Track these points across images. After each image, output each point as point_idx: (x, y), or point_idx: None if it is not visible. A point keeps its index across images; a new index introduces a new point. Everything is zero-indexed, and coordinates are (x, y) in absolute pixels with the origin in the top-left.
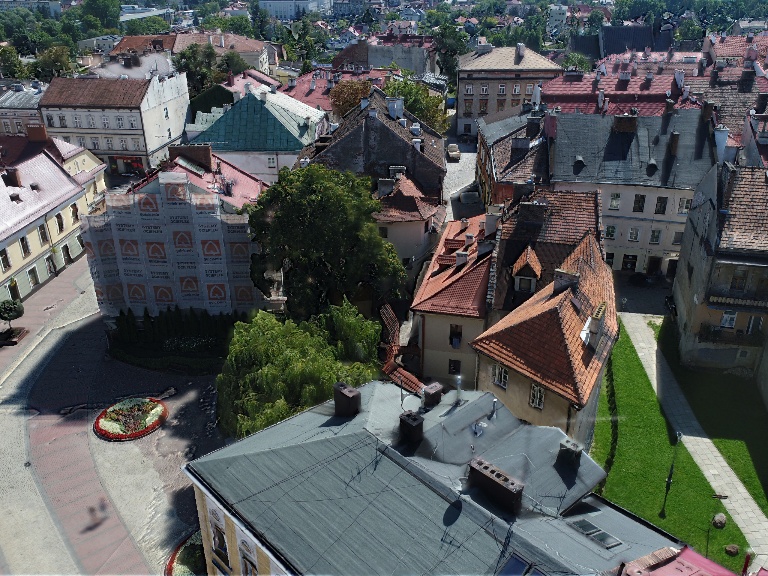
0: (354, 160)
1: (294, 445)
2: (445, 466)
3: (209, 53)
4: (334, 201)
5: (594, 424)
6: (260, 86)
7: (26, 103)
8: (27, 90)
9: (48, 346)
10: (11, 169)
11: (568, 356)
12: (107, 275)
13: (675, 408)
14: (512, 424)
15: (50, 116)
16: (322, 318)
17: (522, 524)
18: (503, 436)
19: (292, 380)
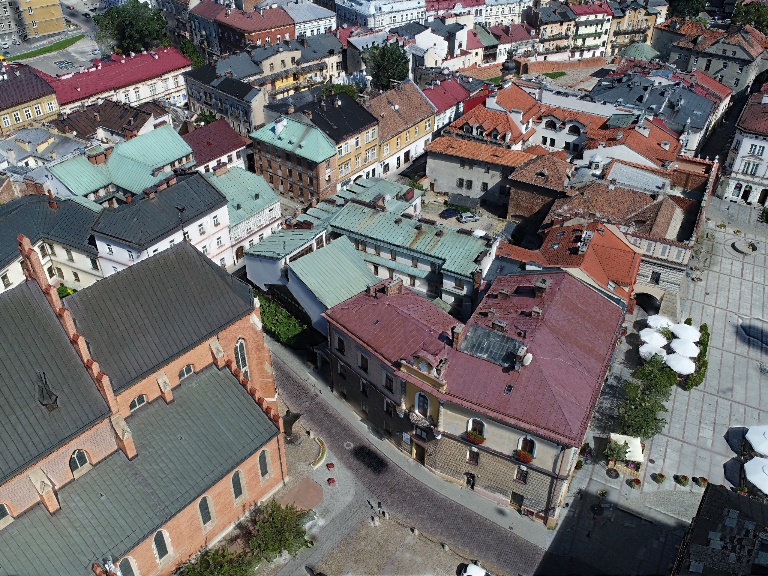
0: None
1: None
2: None
3: None
4: None
5: None
6: None
7: None
8: None
9: None
10: None
11: None
12: None
13: None
14: None
15: None
16: None
17: (618, 3)
18: None
19: None
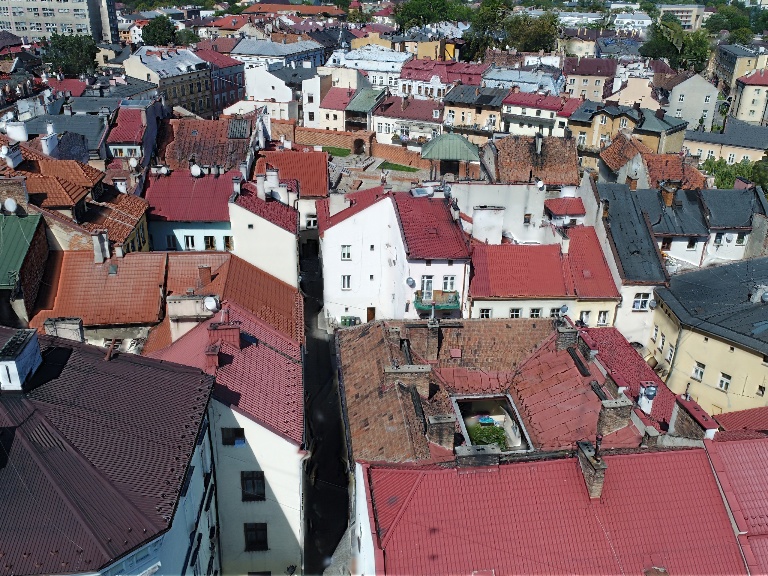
0: None
1: None
2: None
3: None
4: None
5: None
6: None
7: None
8: None
9: None
10: None
11: None
12: None
13: None
14: None
15: None
16: None
17: None
18: None
19: None
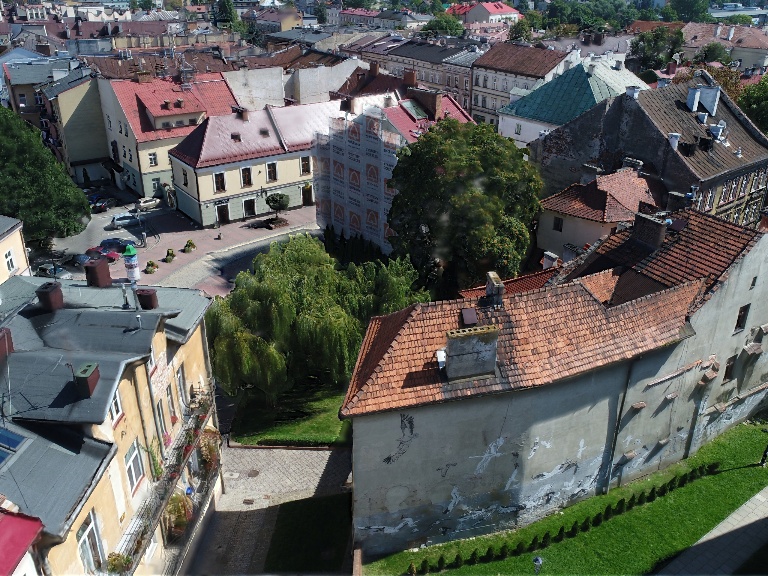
0: (590, 142)
1: (31, 283)
2: (33, 338)
3: (675, 39)
4: (434, 154)
5: (513, 503)
6: None
7: (468, 62)
8: (479, 52)
9: (285, 238)
10: (349, 97)
11: (381, 358)
12: (323, 190)
13: (689, 572)
14: (138, 347)
15: (478, 75)
16: (372, 267)
17: None
18: (115, 350)
19: (248, 290)
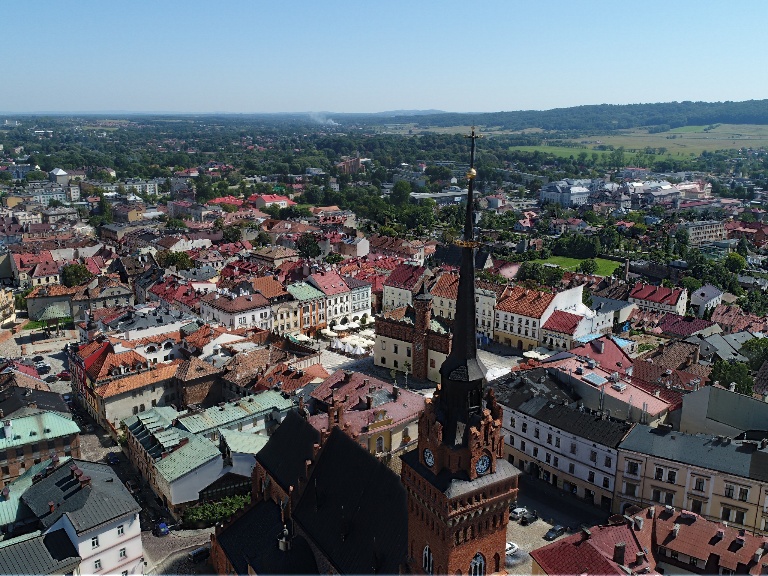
0: None
1: None
2: None
3: (237, 232)
4: (65, 270)
5: None
6: (150, 247)
7: None
8: None
9: None
10: None
11: (31, 292)
12: None
13: None
14: None
15: None
16: None
17: None
18: None
19: None
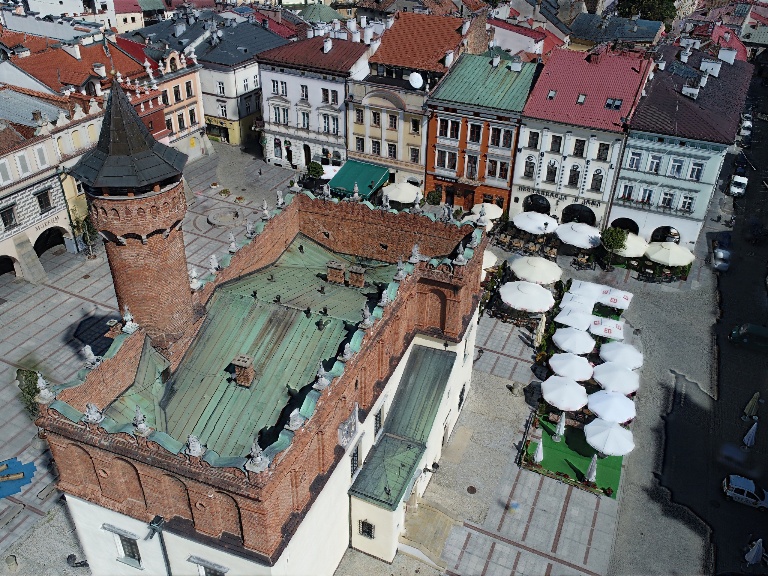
0: None
1: None
2: None
3: None
4: None
5: None
6: None
7: None
8: None
9: None
10: None
11: None
12: None
13: None
14: None
15: None
16: None
17: None
18: None
19: None
